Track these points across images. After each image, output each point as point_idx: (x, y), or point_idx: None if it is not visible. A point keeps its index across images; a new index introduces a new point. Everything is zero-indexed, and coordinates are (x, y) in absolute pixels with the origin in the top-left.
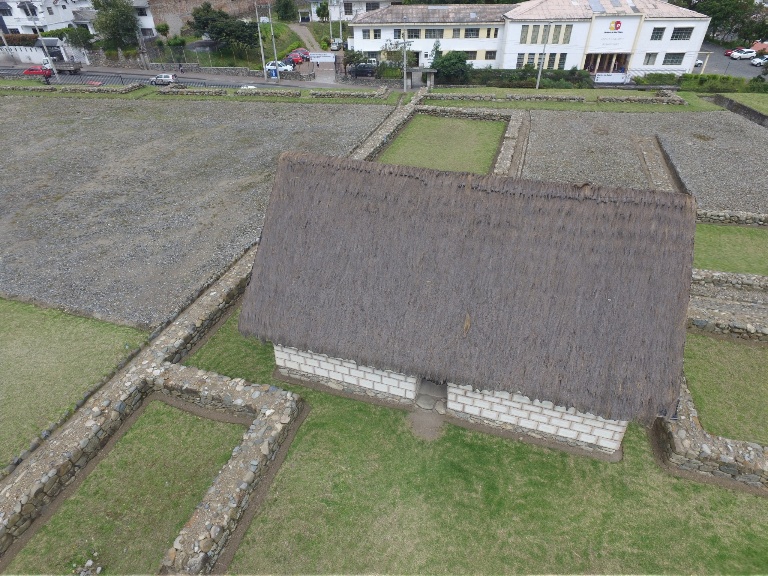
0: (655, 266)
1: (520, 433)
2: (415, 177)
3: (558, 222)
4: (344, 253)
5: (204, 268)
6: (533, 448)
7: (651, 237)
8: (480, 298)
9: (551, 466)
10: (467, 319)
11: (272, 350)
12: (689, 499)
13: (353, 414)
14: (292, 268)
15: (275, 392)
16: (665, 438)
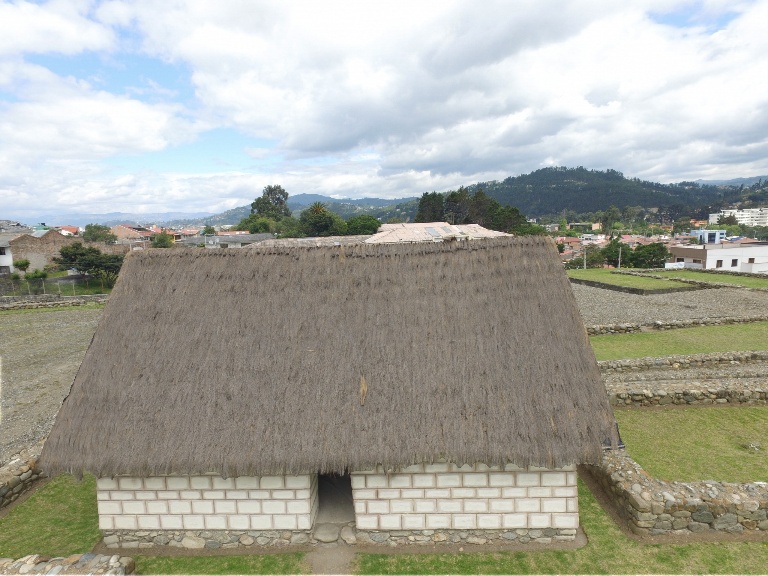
0: (540, 293)
1: (458, 543)
2: (285, 253)
3: (438, 273)
4: (204, 338)
5: (10, 445)
6: (479, 557)
7: (527, 270)
8: (373, 357)
9: (509, 574)
10: (362, 382)
11: (97, 520)
12: (681, 567)
13: (220, 575)
14: (133, 366)
15: (89, 561)
16: (622, 503)
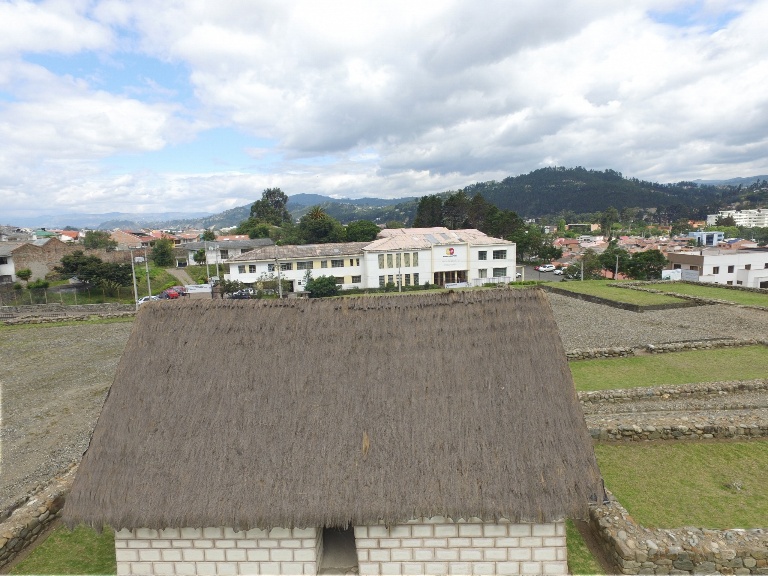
0: (532, 349)
1: None
2: (290, 306)
3: (436, 326)
4: (215, 392)
5: (25, 480)
6: None
7: (520, 325)
8: (375, 412)
9: None
10: (364, 438)
11: (113, 562)
12: None
13: None
14: (148, 421)
15: None
16: (609, 548)
